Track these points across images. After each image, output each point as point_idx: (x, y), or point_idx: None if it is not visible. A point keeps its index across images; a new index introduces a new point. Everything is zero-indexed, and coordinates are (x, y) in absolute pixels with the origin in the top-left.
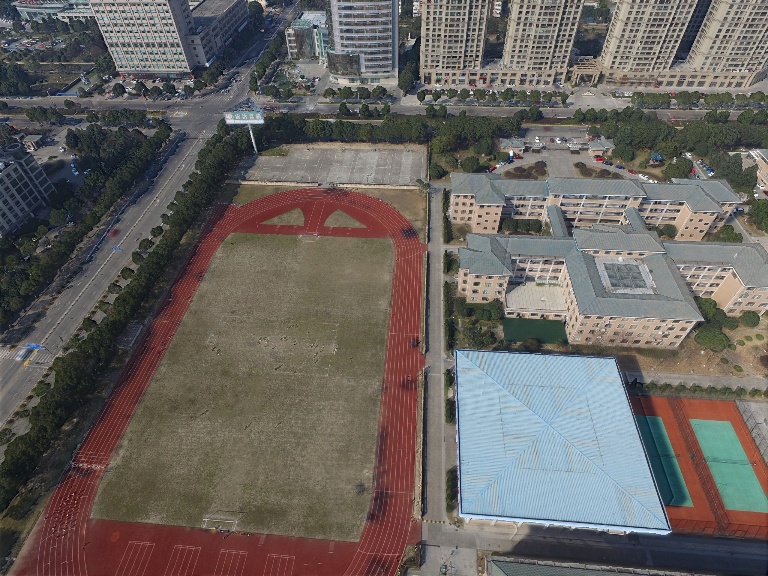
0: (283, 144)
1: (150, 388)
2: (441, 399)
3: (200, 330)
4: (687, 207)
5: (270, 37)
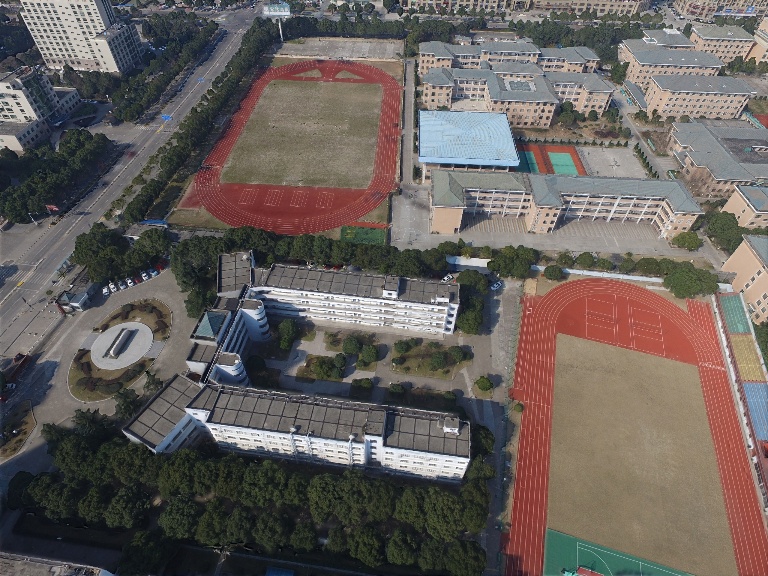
0: (301, 37)
1: (239, 141)
2: (411, 145)
3: (263, 120)
4: (566, 62)
5: None
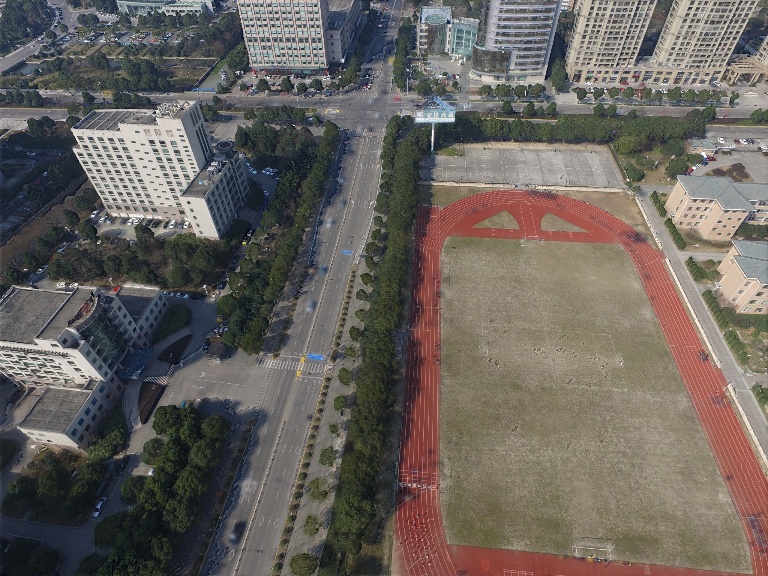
0: (456, 143)
1: (443, 402)
2: (762, 417)
3: (466, 340)
4: None
5: (385, 33)
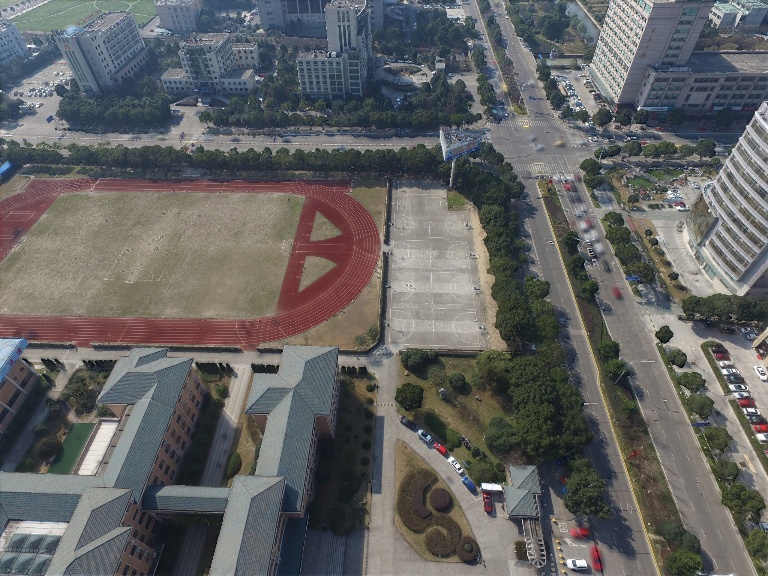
0: None
1: (141, 193)
2: (37, 359)
3: (186, 203)
4: None
5: None
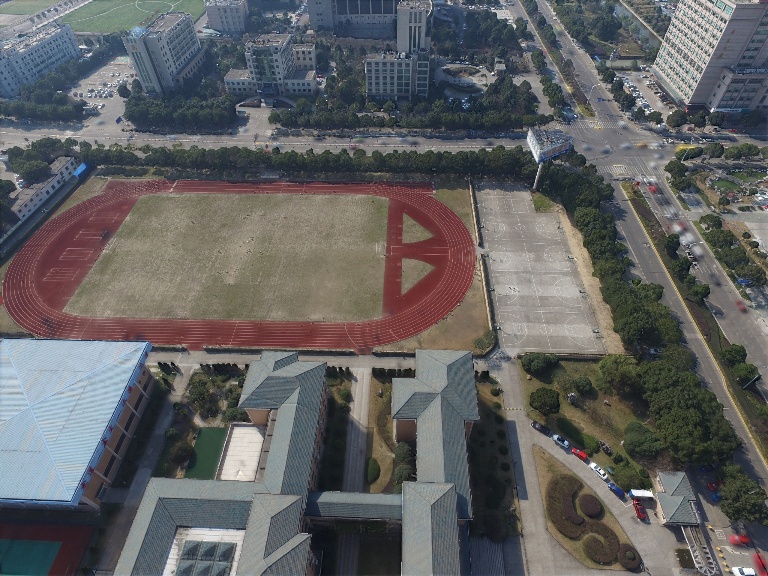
0: (561, 205)
1: (222, 195)
2: (151, 362)
3: (269, 205)
4: None
5: None
